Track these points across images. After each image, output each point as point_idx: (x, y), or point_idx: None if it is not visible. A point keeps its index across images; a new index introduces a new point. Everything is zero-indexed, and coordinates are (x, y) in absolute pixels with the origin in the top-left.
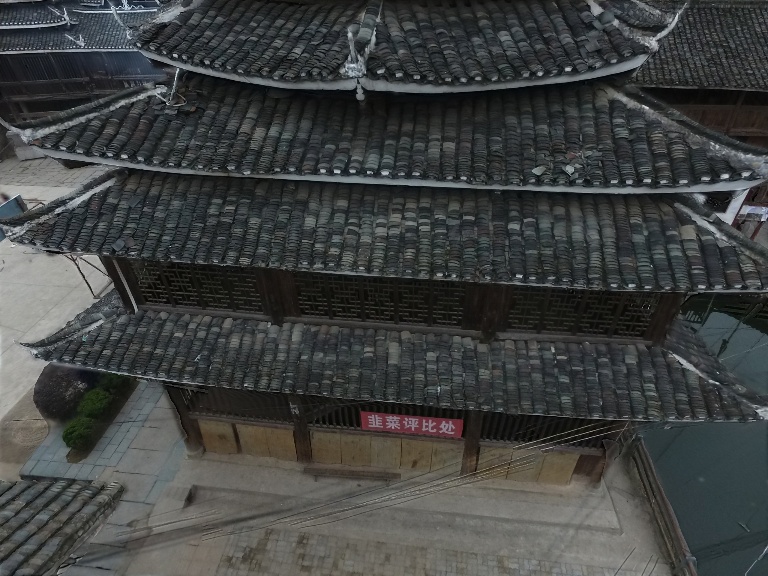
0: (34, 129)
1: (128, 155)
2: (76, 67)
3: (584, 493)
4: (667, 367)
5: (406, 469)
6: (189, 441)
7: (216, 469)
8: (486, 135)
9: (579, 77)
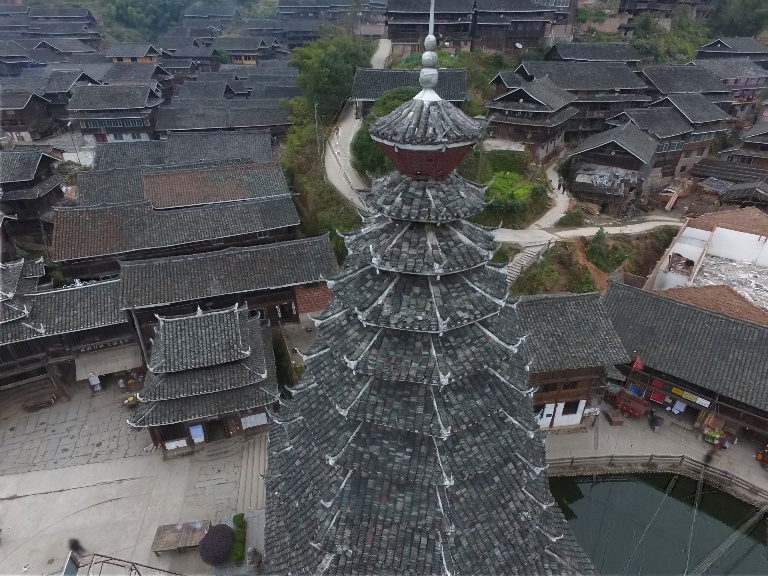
0: None
1: None
2: (32, 346)
3: None
4: None
5: None
6: None
7: None
8: None
9: None
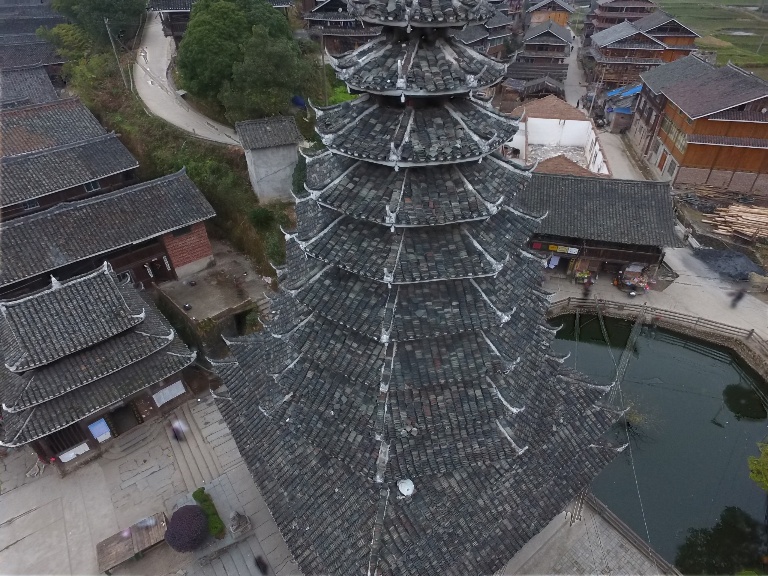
0: (376, 568)
1: None
2: None
3: None
4: (586, 450)
5: None
6: None
7: None
8: None
9: None
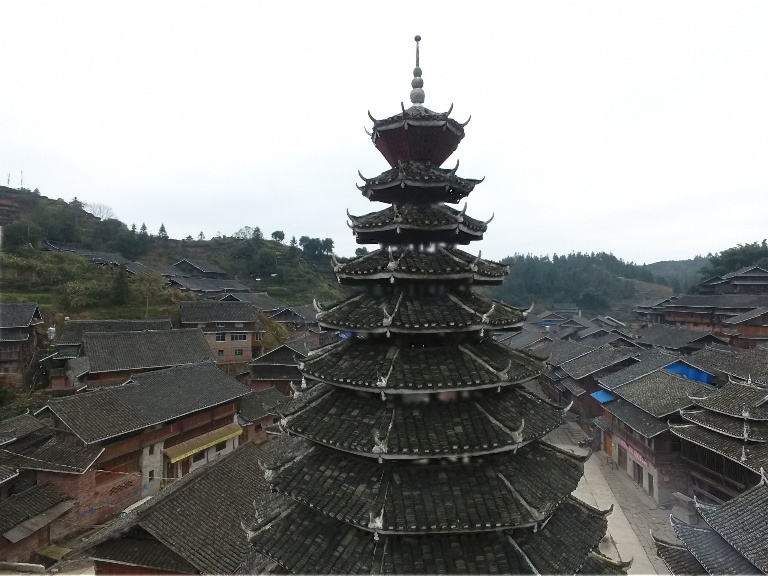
0: None
1: None
2: (740, 473)
3: None
4: None
5: None
6: None
7: None
8: None
9: None
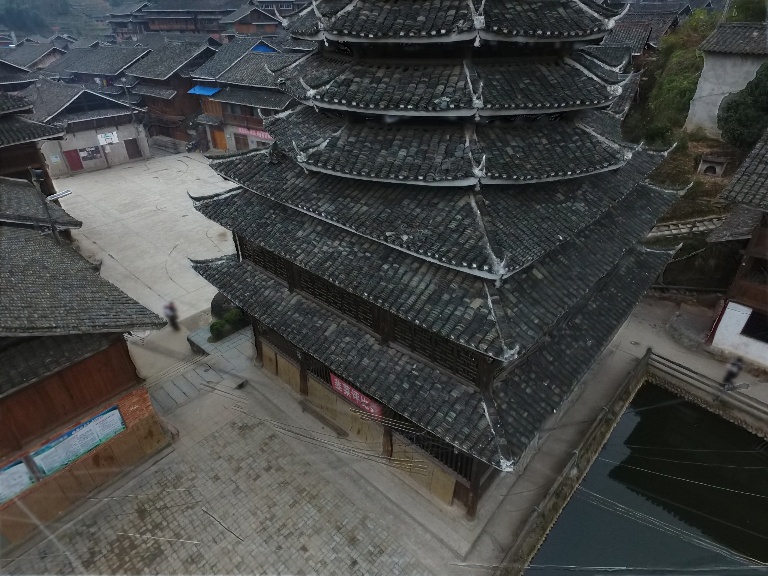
0: (213, 159)
1: (238, 179)
2: None
3: (458, 519)
4: (474, 409)
5: (353, 433)
6: (257, 355)
7: (262, 378)
8: (386, 207)
9: (432, 184)
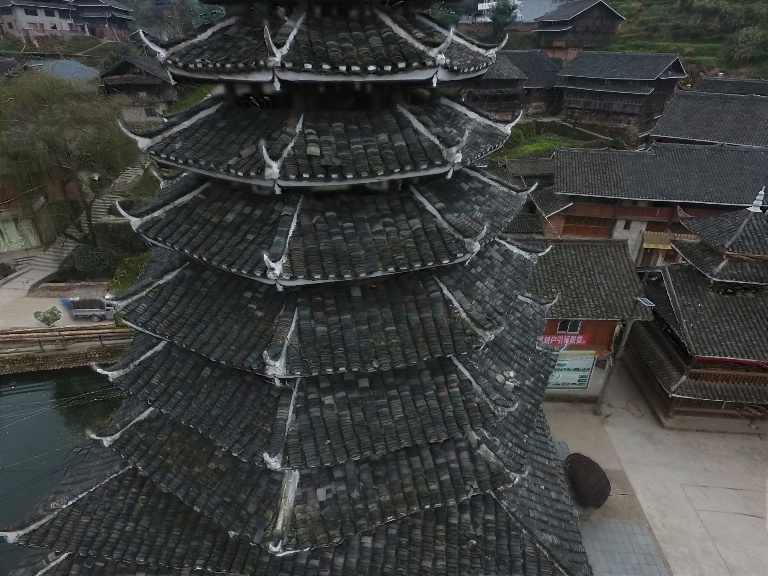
0: None
1: None
2: None
3: None
4: None
5: None
6: None
7: None
8: None
9: None
